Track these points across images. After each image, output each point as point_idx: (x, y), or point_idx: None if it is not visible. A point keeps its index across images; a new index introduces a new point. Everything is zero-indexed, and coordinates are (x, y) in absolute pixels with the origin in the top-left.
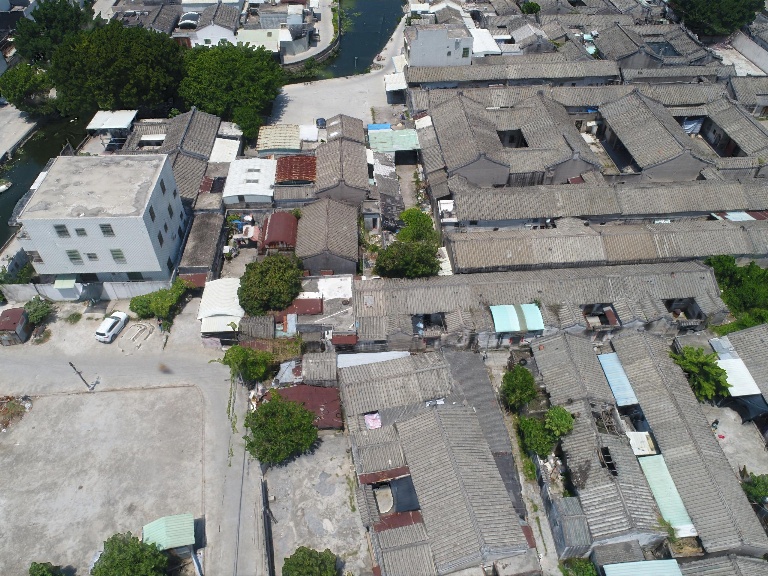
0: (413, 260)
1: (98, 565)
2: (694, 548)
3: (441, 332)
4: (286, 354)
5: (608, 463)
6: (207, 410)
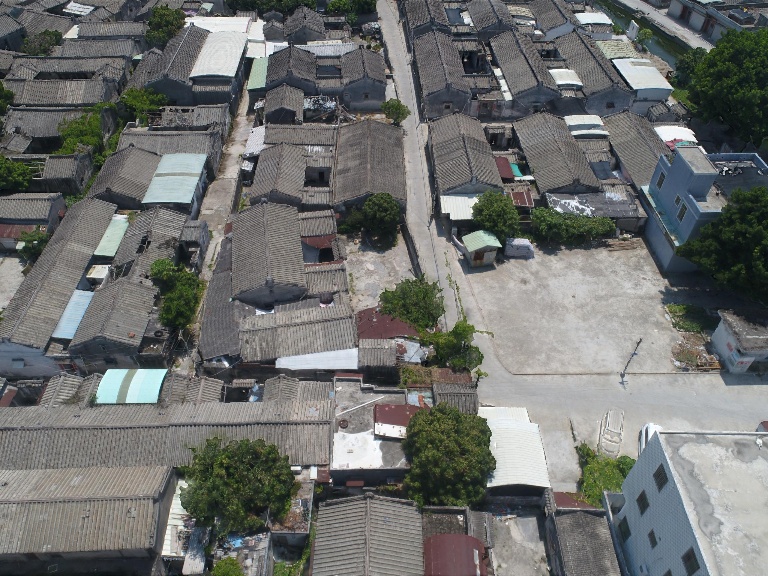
0: (236, 448)
1: (516, 211)
2: (122, 212)
3: (231, 385)
4: (416, 369)
5: (144, 245)
6: (491, 349)
